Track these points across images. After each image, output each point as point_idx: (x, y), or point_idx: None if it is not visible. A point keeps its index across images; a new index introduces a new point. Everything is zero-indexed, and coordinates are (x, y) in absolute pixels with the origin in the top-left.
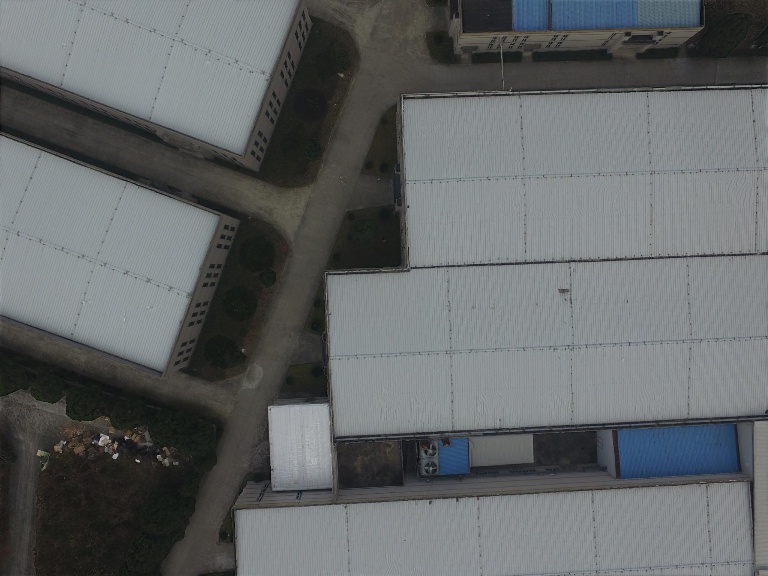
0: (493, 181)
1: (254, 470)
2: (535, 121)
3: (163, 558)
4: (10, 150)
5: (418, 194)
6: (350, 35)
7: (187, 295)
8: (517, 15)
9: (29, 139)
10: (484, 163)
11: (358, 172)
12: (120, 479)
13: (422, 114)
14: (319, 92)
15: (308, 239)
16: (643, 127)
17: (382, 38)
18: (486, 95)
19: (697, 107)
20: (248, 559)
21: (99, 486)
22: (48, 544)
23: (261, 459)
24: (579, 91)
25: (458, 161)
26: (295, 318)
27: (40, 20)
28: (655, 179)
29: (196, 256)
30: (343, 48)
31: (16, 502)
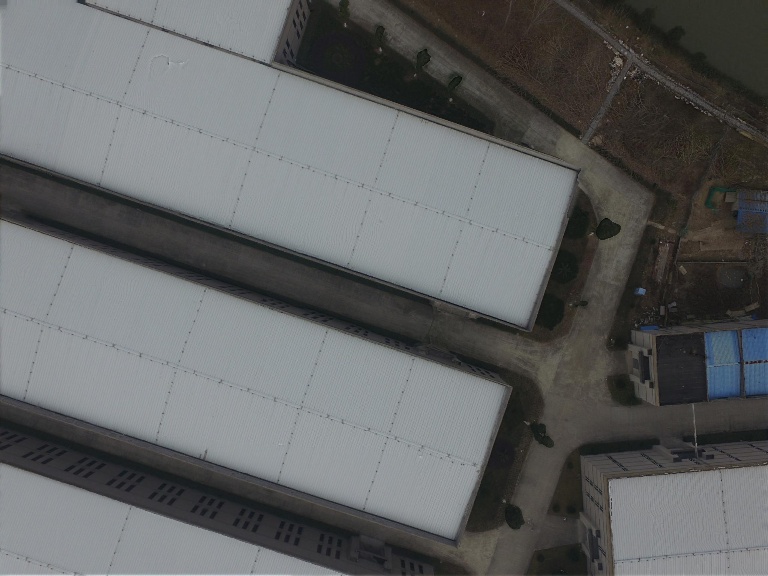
0: (698, 556)
1: None
2: (736, 494)
3: None
4: (231, 546)
5: (626, 572)
6: (534, 383)
7: None
8: (710, 382)
9: (227, 497)
10: (689, 539)
11: (545, 513)
12: None
13: (626, 493)
14: (507, 442)
15: None
16: None
17: (565, 383)
18: (687, 471)
19: None
20: None
21: None
22: None
23: None
24: None
25: (663, 538)
26: None
27: (258, 423)
28: None
29: None
30: (528, 396)
31: None
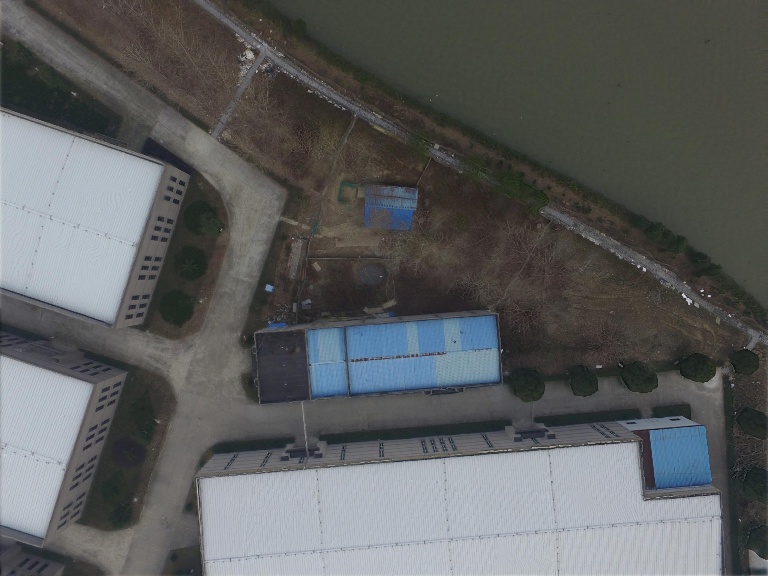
0: (291, 556)
1: None
2: (332, 494)
3: None
4: None
5: (218, 572)
6: (165, 380)
7: None
8: (316, 380)
9: None
10: (282, 539)
11: (179, 512)
12: None
13: (220, 492)
14: None
15: None
16: (440, 494)
17: (197, 381)
18: (283, 470)
19: (494, 471)
20: None
21: None
22: None
23: None
24: (375, 461)
25: (256, 538)
26: None
27: None
28: (453, 546)
29: None
30: (158, 394)
31: None
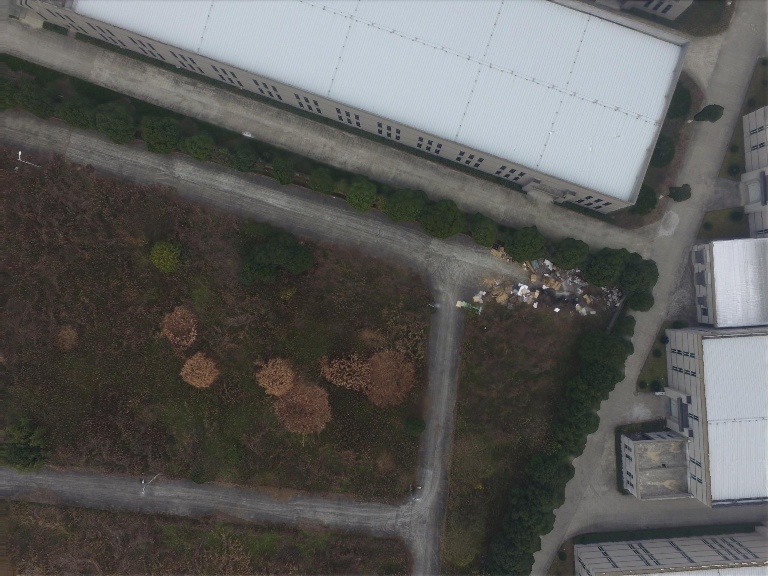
0: None
1: (671, 318)
2: None
3: (606, 399)
4: None
5: None
6: None
7: (655, 122)
8: None
9: None
10: None
11: None
12: (539, 329)
13: None
14: None
15: (722, 86)
16: None
17: None
18: None
19: None
20: (715, 389)
21: (518, 336)
22: (476, 392)
23: (678, 307)
24: None
25: None
26: (710, 164)
27: None
28: None
29: (660, 85)
30: None
31: (435, 354)
